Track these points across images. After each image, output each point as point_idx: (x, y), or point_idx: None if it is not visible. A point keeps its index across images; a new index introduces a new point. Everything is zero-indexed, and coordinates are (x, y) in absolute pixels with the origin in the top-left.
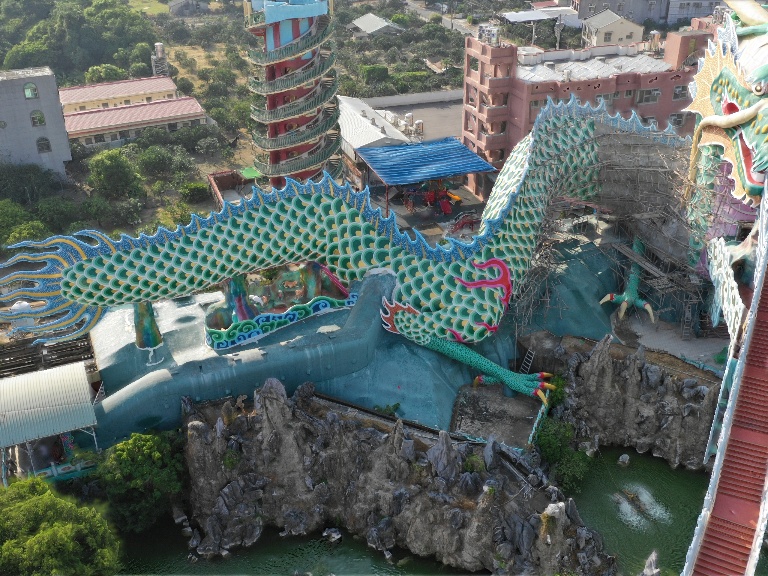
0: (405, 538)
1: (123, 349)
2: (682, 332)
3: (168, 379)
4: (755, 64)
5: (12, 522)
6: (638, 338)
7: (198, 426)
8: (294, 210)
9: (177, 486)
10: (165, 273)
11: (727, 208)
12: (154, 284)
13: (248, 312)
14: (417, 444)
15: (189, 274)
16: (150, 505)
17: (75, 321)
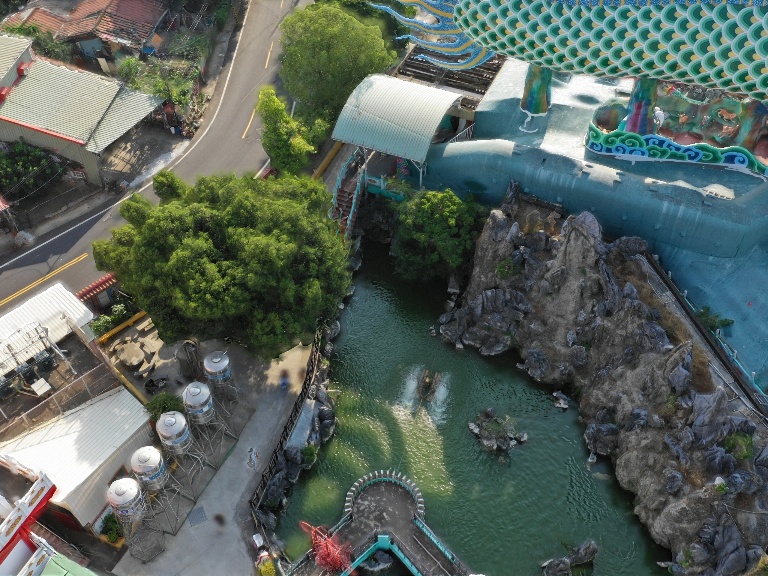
0: (617, 457)
1: (508, 100)
2: None
3: (507, 155)
4: None
5: (261, 214)
6: None
7: (497, 218)
8: (762, 26)
9: (457, 261)
10: (556, 41)
11: None
12: (540, 48)
13: (641, 125)
14: (699, 379)
15: (582, 53)
16: (425, 263)
17: (460, 52)
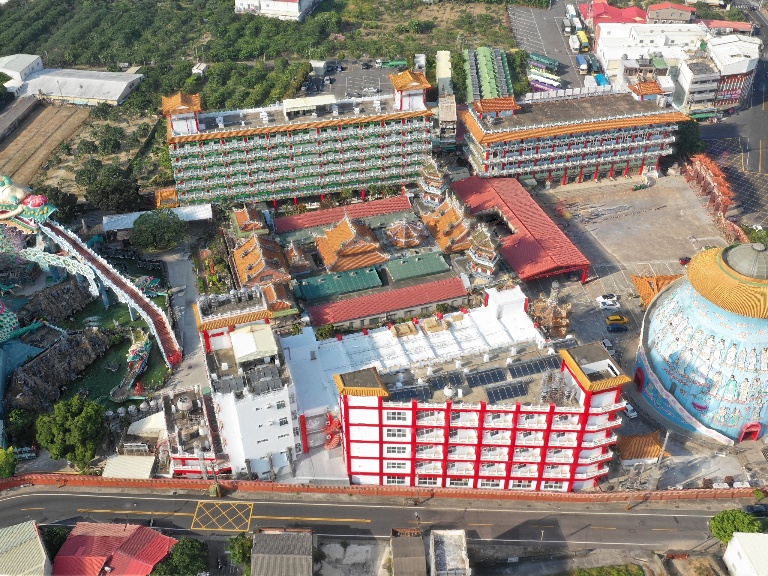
0: None
1: None
2: (31, 284)
3: None
4: (7, 197)
5: None
6: (25, 295)
7: None
8: None
9: None
10: None
11: (16, 239)
12: None
13: None
14: None
15: None
16: None
17: None
